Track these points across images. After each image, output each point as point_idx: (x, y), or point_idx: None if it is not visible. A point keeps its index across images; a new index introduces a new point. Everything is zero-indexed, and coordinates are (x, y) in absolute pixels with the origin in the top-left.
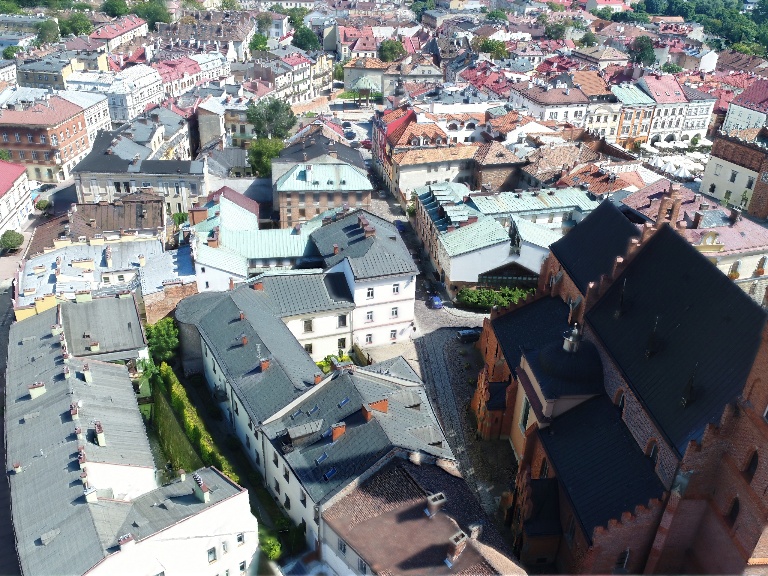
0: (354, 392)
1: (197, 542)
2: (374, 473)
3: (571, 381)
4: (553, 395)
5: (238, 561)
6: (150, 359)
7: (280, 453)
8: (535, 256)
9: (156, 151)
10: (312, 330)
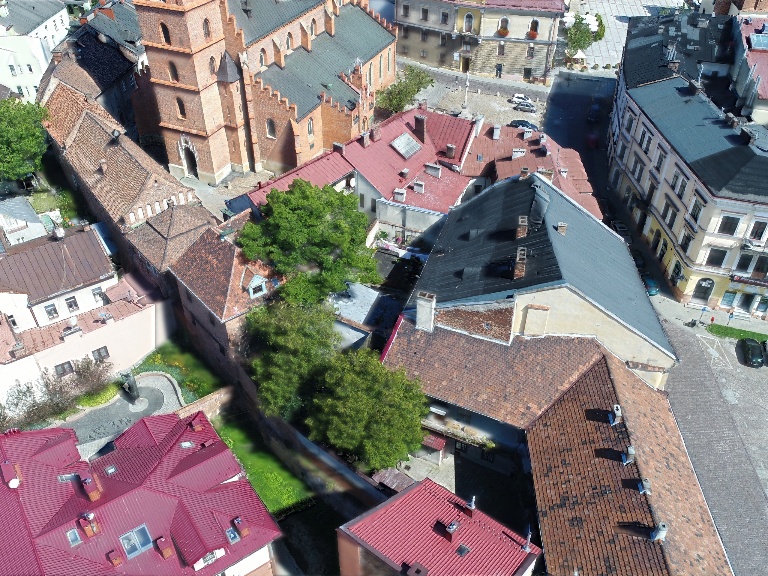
0: None
1: (1, 56)
2: None
3: None
4: None
5: (32, 84)
6: None
7: None
8: None
9: None
10: None
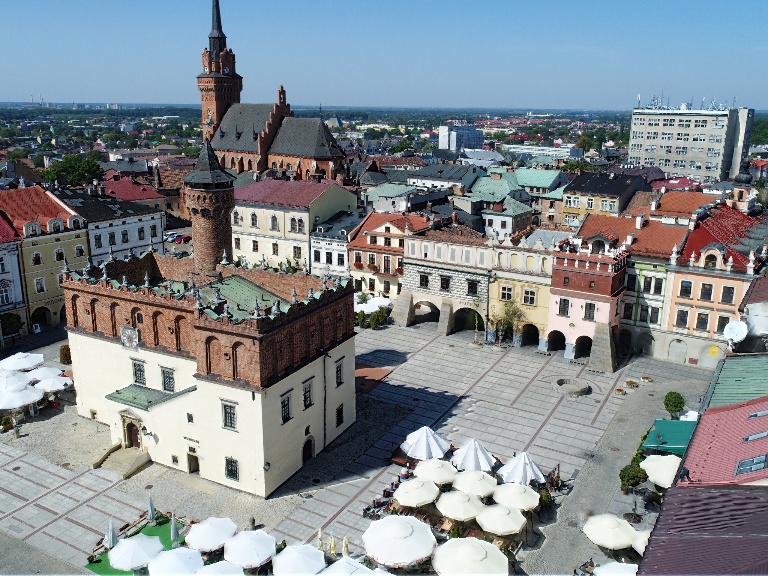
0: None
1: None
2: None
3: None
4: None
5: None
6: None
7: None
8: None
9: None
10: None
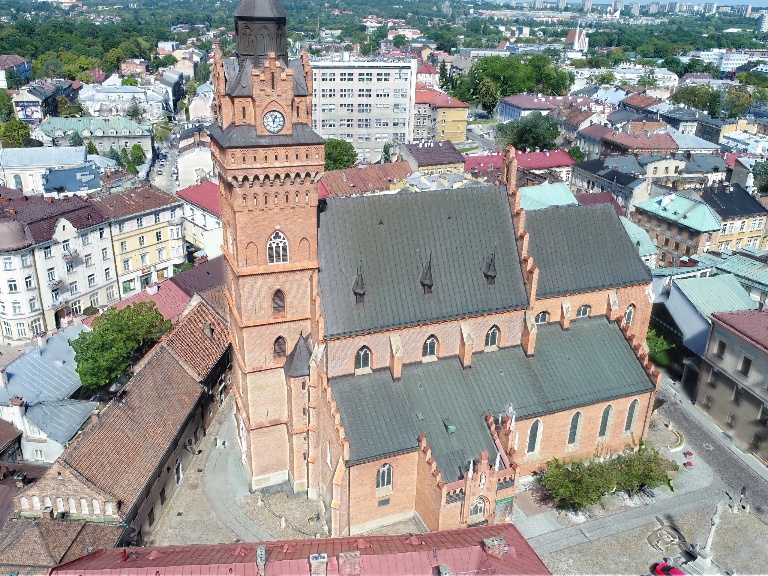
0: None
1: None
2: None
3: None
4: None
5: None
6: None
7: None
8: (680, 305)
9: (655, 176)
10: None
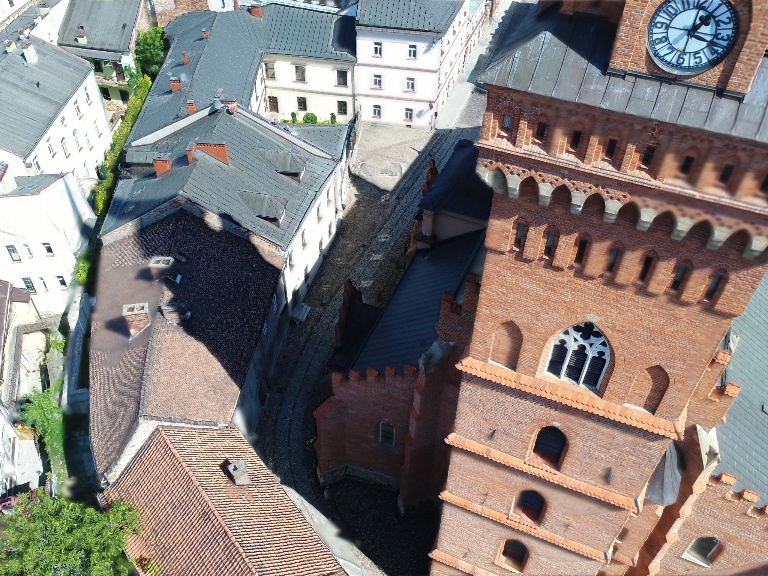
0: (210, 131)
1: None
2: (157, 220)
3: (468, 195)
4: (430, 204)
5: (52, 273)
6: (137, 69)
7: (119, 177)
8: None
9: None
10: (305, 80)
